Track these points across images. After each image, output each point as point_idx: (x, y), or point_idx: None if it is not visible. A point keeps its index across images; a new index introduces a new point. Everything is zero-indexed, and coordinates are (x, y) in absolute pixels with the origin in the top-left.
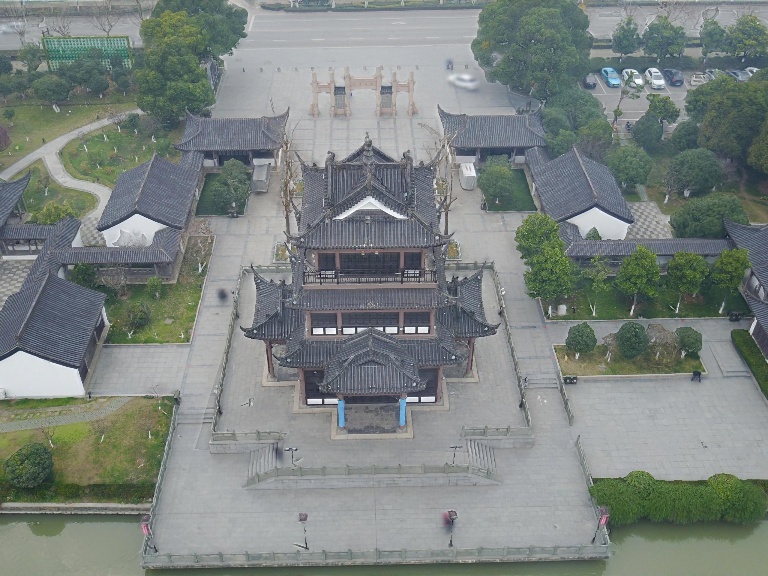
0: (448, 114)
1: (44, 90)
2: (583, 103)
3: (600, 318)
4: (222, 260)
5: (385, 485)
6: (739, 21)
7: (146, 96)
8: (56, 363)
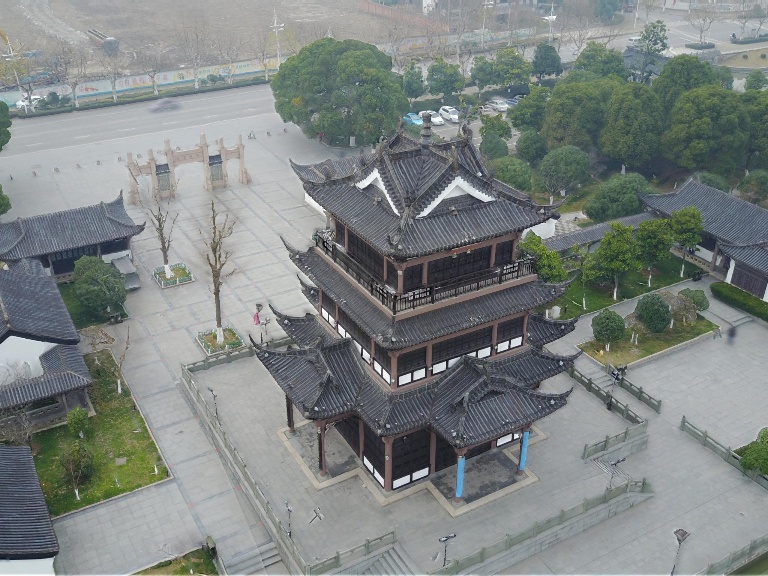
0: (305, 166)
1: None
2: None
3: (593, 310)
4: (138, 372)
5: (546, 546)
6: (499, 55)
7: None
8: (19, 559)
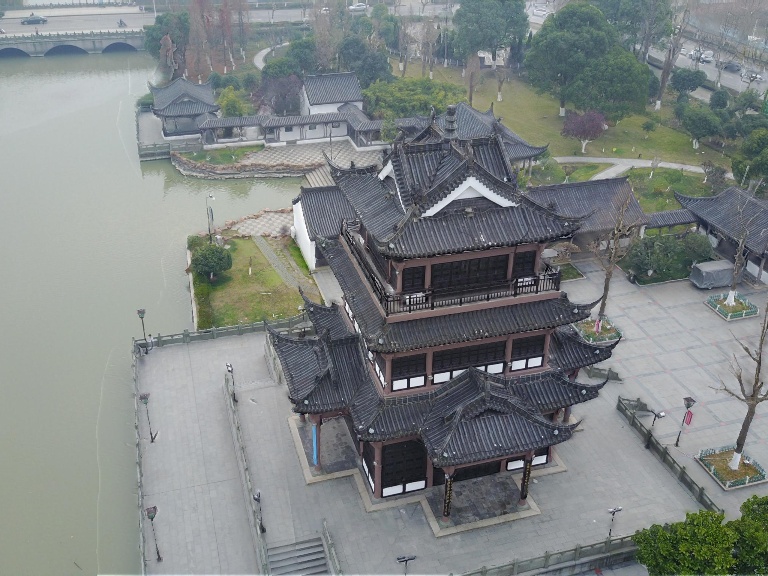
0: None
1: (687, 117)
2: None
3: None
4: None
5: None
6: None
7: (740, 154)
8: None
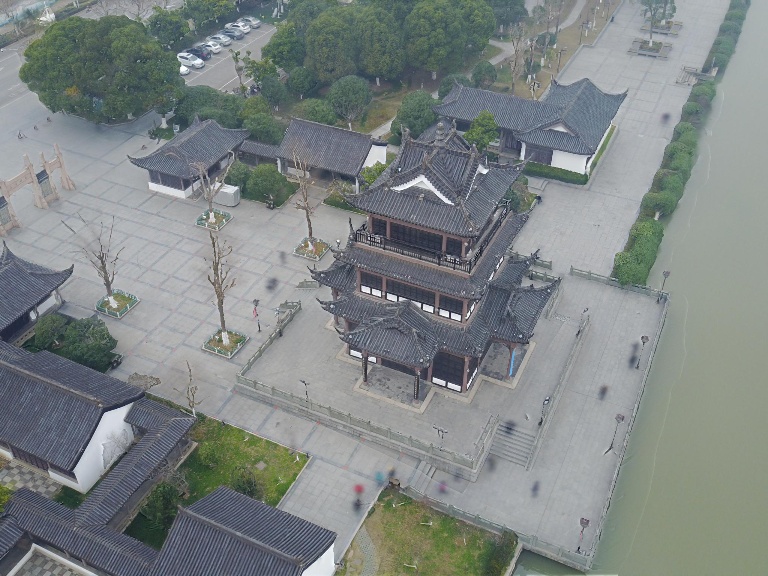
0: (145, 158)
1: None
2: (216, 94)
3: None
4: None
5: None
6: None
7: None
8: (323, 554)
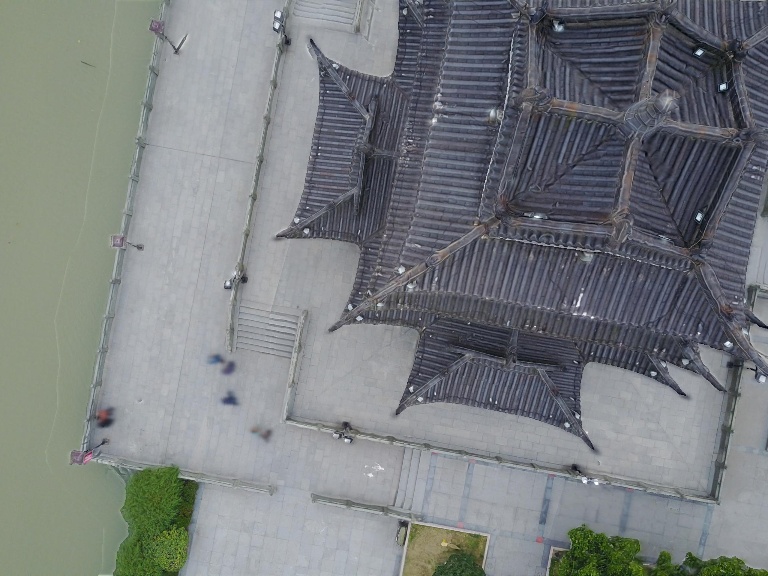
0: None
1: None
2: None
3: None
4: None
5: None
6: None
7: None
8: None
